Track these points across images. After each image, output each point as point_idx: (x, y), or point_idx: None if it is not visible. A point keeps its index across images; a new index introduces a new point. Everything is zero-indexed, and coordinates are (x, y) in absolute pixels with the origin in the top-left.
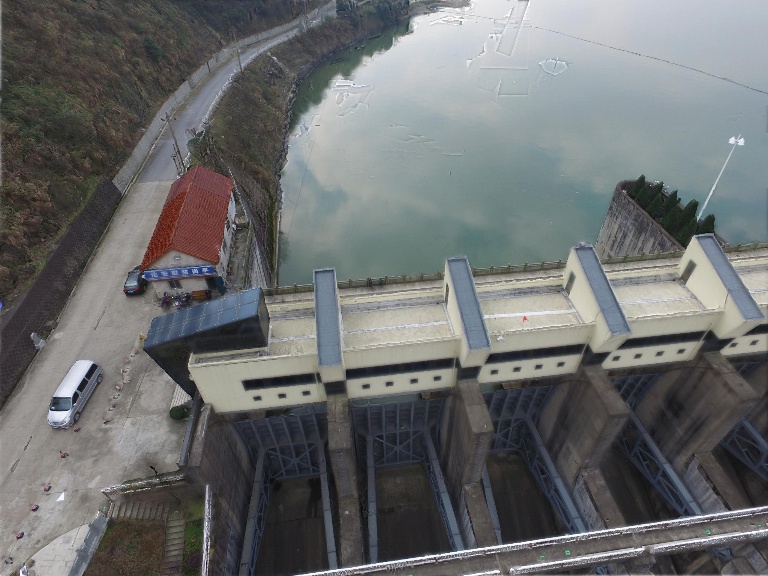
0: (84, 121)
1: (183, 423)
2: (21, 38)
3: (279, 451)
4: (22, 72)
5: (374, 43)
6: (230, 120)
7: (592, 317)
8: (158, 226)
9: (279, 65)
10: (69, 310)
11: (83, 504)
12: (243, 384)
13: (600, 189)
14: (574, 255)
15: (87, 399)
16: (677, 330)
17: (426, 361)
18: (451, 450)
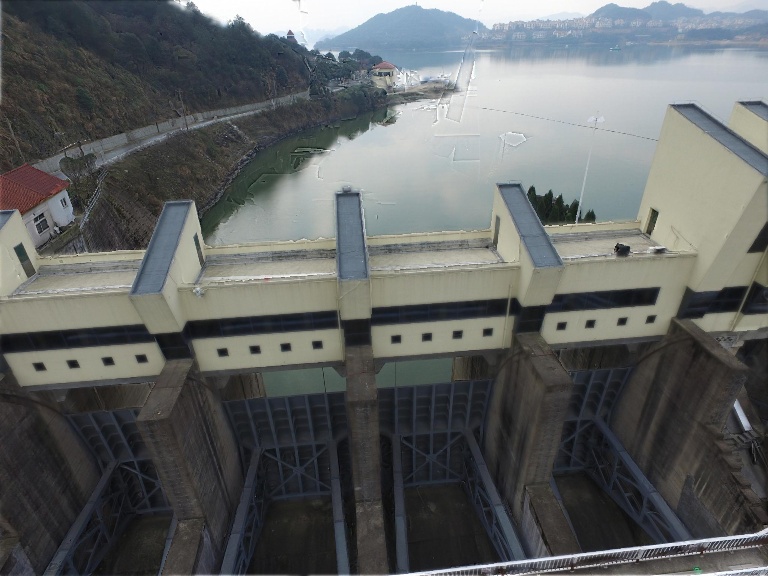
0: None
1: None
2: None
3: None
4: None
5: (349, 125)
6: (143, 159)
7: None
8: None
9: (239, 133)
10: None
11: None
12: None
13: None
14: None
15: None
16: (465, 295)
17: (115, 328)
18: None
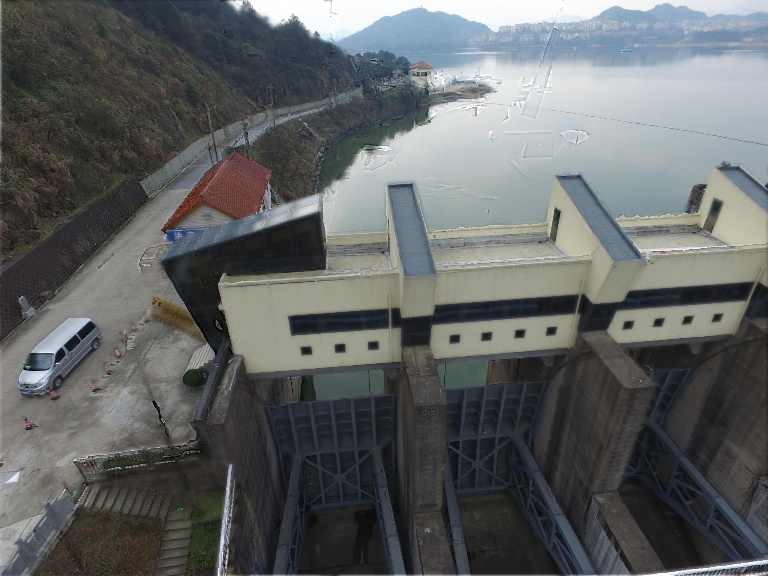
0: (118, 121)
1: (200, 392)
2: (67, 54)
3: (320, 461)
4: (63, 72)
5: (397, 124)
6: (264, 153)
7: (764, 239)
8: (187, 198)
9: (309, 130)
10: (71, 284)
11: (44, 487)
12: (290, 323)
13: None
14: (718, 175)
15: (75, 364)
16: None
17: (539, 300)
18: (561, 454)
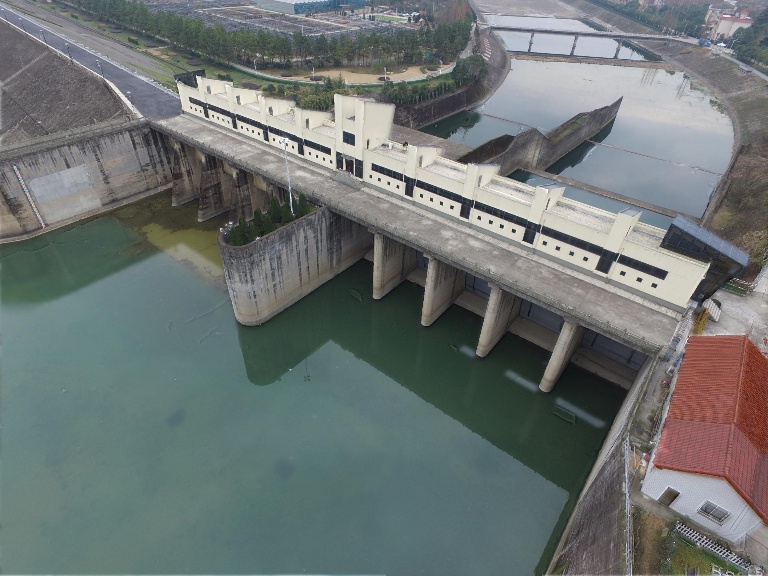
0: None
1: None
2: None
3: None
4: None
5: None
6: None
7: None
8: None
9: None
10: None
11: (767, 301)
12: None
13: (43, 374)
14: None
15: None
16: None
17: None
18: None
